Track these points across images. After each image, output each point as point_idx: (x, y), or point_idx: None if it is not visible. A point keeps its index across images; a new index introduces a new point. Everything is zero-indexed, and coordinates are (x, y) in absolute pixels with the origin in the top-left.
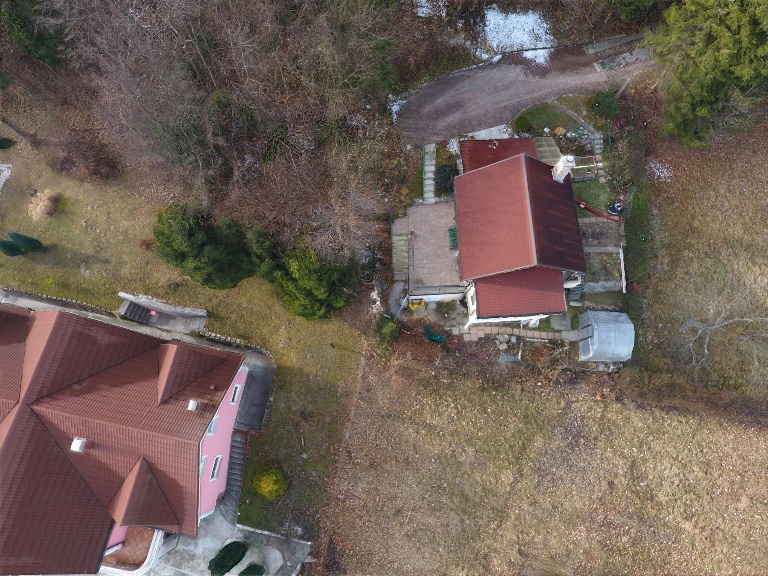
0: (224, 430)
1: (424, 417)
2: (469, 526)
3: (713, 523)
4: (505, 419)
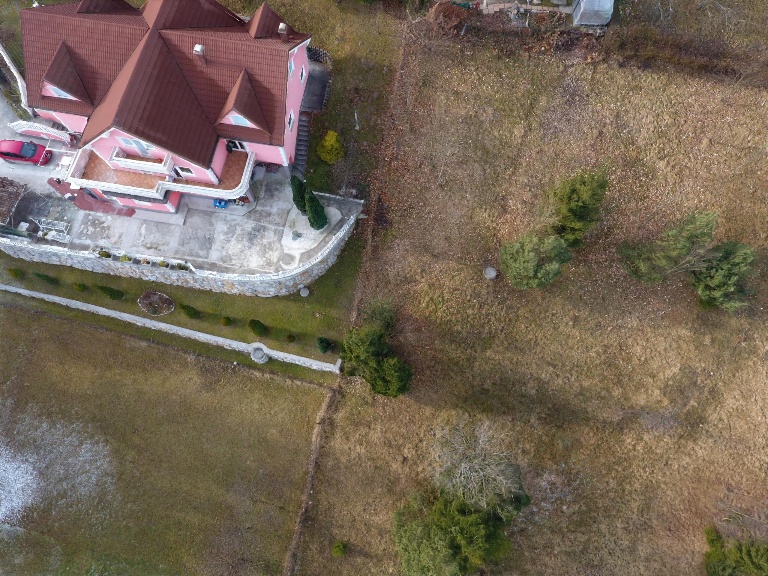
0: (296, 94)
1: (453, 85)
2: (490, 174)
3: (681, 162)
4: (516, 82)
